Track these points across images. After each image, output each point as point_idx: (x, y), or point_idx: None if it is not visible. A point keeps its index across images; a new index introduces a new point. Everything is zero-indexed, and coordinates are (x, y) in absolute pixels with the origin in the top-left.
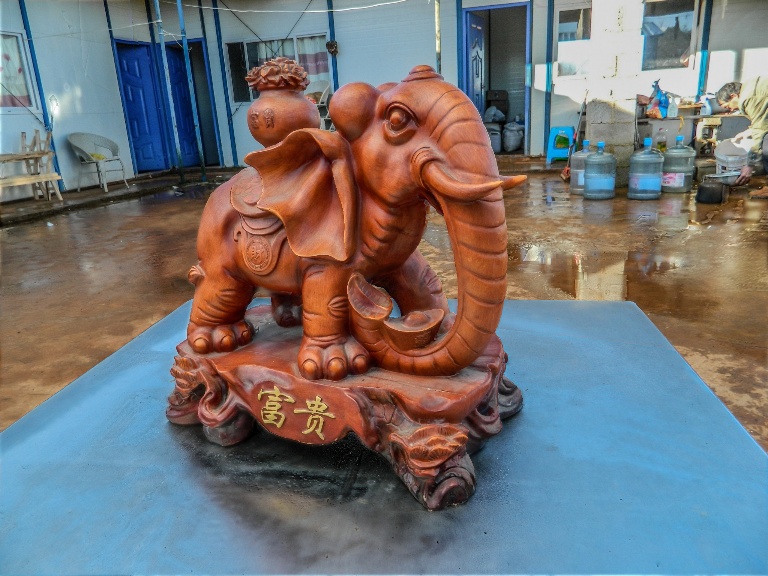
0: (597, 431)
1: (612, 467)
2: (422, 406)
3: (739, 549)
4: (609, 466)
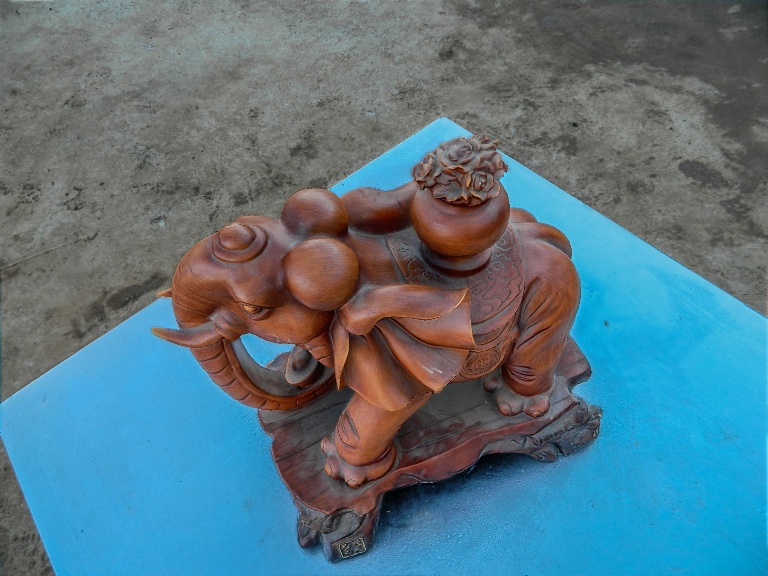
0: (225, 562)
1: (197, 515)
2: (280, 355)
3: (107, 491)
4: (199, 514)
